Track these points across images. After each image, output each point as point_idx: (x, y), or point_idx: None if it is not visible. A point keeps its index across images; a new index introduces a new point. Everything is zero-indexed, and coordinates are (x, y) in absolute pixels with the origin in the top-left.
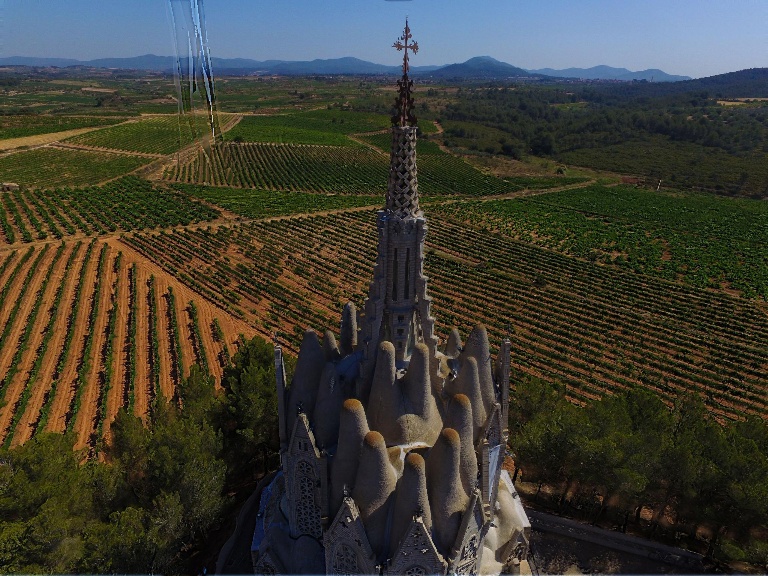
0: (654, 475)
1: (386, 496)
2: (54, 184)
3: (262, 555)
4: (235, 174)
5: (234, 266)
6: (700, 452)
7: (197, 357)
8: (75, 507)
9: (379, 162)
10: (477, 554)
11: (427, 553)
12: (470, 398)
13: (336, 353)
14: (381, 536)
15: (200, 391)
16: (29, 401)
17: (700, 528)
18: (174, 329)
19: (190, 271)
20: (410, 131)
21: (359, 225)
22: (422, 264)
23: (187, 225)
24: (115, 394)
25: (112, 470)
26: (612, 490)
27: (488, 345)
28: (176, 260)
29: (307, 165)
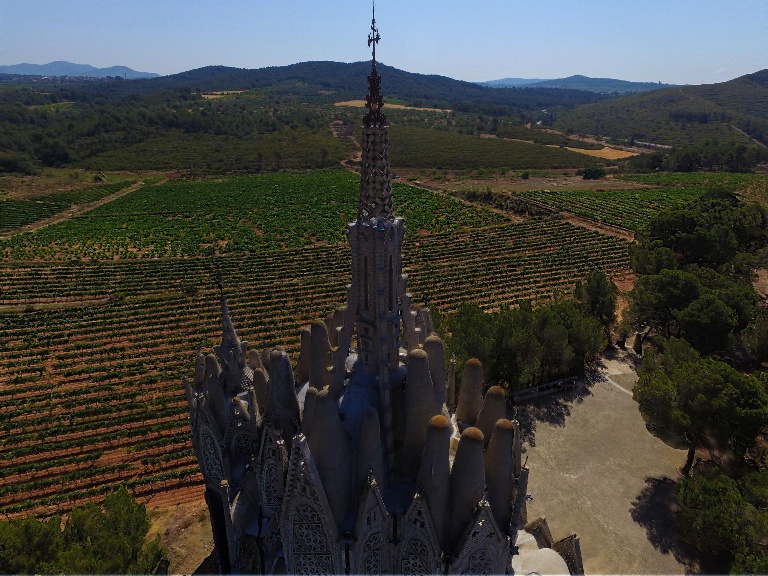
0: None
1: None
2: None
3: None
4: None
5: None
6: None
7: None
8: None
9: None
10: None
11: None
12: None
13: None
14: None
15: None
16: None
17: (491, 383)
18: None
19: None
20: None
21: None
22: None
23: None
24: None
25: None
26: None
27: None
28: None
29: None
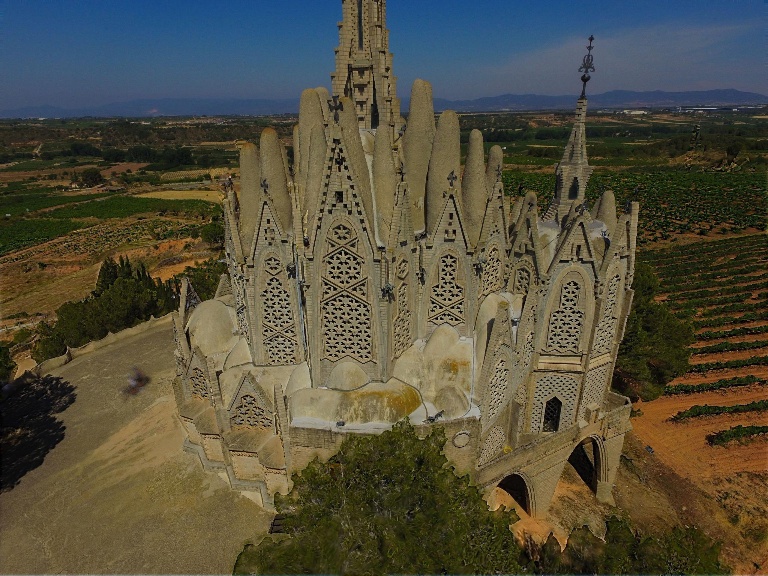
0: None
1: None
2: None
3: None
4: None
5: None
6: None
7: (765, 362)
8: None
9: None
10: None
11: None
12: None
13: None
14: None
15: None
16: None
17: None
18: None
19: None
20: None
21: None
22: (344, 8)
23: None
24: None
25: None
26: None
27: None
28: None
29: None
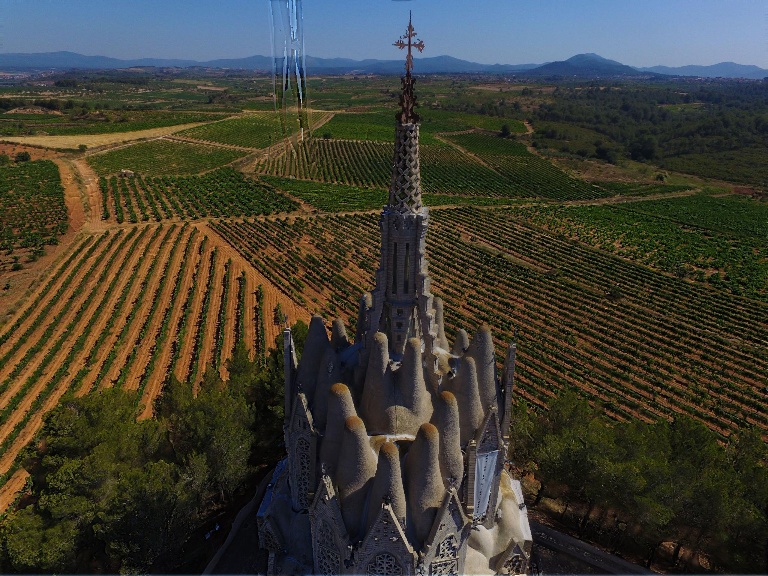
0: (684, 510)
1: (364, 481)
2: (162, 172)
3: (264, 521)
4: (320, 169)
5: (304, 256)
6: (742, 493)
7: (257, 337)
8: (123, 454)
9: (461, 162)
10: (458, 555)
11: (397, 542)
12: (466, 398)
13: (344, 341)
14: (358, 519)
15: (243, 367)
16: (114, 361)
17: None
18: (241, 310)
19: (264, 258)
20: (411, 128)
21: (430, 224)
22: (422, 260)
23: (268, 215)
24: (183, 363)
25: (157, 427)
26: (634, 519)
27: (492, 347)
28: (253, 247)
29: (389, 163)
